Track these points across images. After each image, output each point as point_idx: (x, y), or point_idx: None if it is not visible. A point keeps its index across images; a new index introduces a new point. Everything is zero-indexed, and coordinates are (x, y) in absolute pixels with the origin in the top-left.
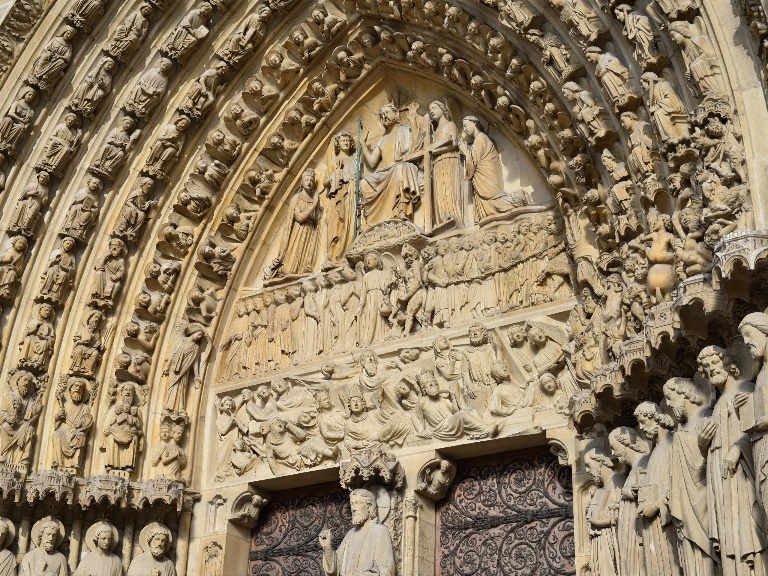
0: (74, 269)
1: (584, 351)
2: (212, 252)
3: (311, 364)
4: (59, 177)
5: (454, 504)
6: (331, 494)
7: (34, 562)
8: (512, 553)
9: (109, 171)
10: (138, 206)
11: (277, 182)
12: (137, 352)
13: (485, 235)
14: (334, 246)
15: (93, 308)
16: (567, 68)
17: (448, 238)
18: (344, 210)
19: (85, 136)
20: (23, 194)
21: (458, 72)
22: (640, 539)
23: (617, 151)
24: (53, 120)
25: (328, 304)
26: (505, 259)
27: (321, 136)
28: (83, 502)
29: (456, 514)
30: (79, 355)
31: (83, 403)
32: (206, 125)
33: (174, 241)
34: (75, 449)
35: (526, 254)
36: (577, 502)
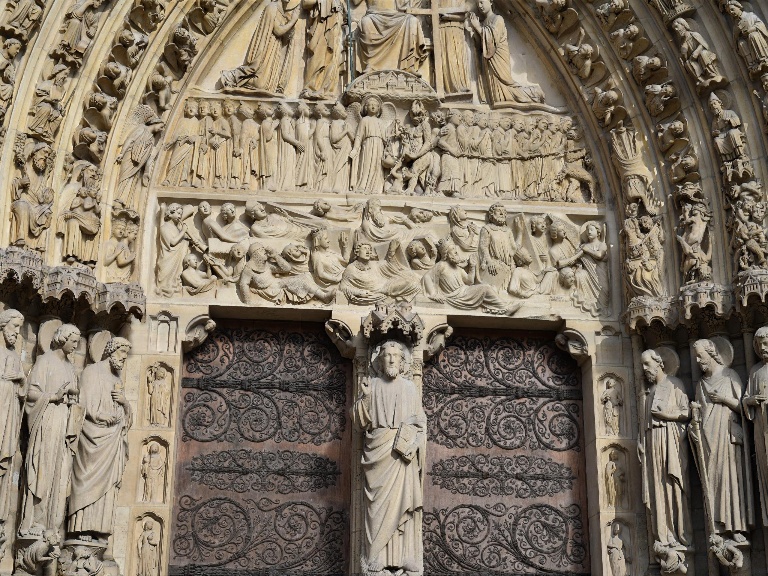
0: None
1: (645, 262)
2: (189, 38)
3: (293, 195)
4: None
5: (439, 368)
6: (289, 333)
7: None
8: (501, 423)
9: None
10: None
11: None
12: (93, 127)
13: (502, 119)
14: (318, 75)
15: (62, 61)
16: (683, 5)
17: (462, 109)
18: (333, 40)
19: None
20: None
21: None
22: (734, 438)
23: (721, 98)
24: None
25: (312, 135)
26: (524, 148)
27: None
28: (45, 293)
29: (440, 378)
30: (47, 115)
31: (41, 173)
32: None
33: (151, 11)
34: (42, 228)
35: (545, 150)
36: (597, 390)
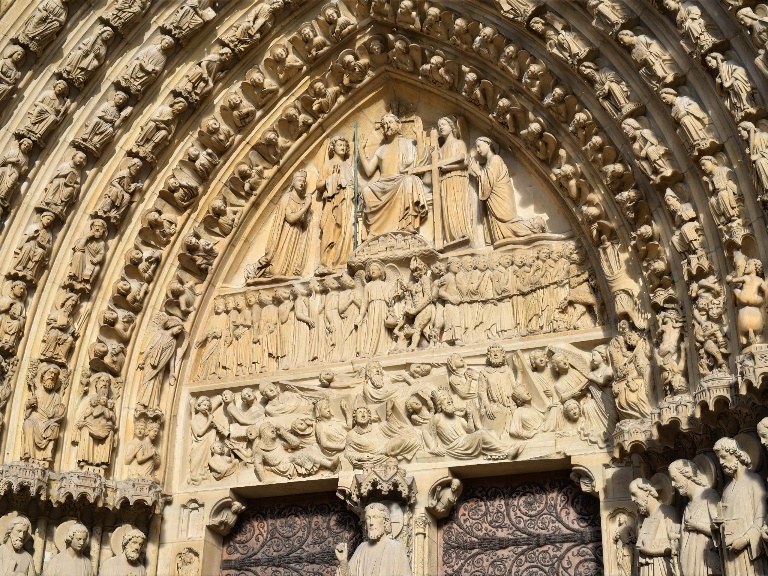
0: (50, 247)
1: (629, 382)
2: (198, 244)
3: (304, 370)
4: (40, 146)
5: (458, 523)
6: (317, 505)
7: (2, 561)
8: (523, 575)
9: (97, 147)
10: (124, 187)
11: (266, 179)
12: (111, 342)
13: (501, 257)
14: (329, 251)
15: (70, 291)
16: (629, 105)
17: (461, 256)
18: (341, 216)
19: (72, 106)
20: (2, 160)
21: (480, 92)
22: (710, 570)
23: (680, 192)
24: (38, 85)
25: (323, 310)
26: (524, 283)
27: (314, 137)
28: (55, 498)
29: (460, 533)
30: (54, 340)
31: (55, 391)
32: (200, 111)
33: (158, 228)
34: (48, 441)
35: (546, 280)
36: (606, 529)
